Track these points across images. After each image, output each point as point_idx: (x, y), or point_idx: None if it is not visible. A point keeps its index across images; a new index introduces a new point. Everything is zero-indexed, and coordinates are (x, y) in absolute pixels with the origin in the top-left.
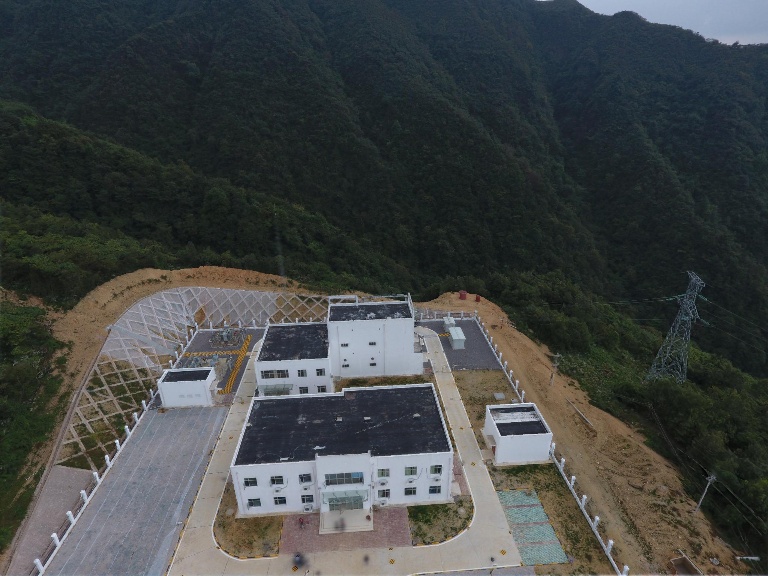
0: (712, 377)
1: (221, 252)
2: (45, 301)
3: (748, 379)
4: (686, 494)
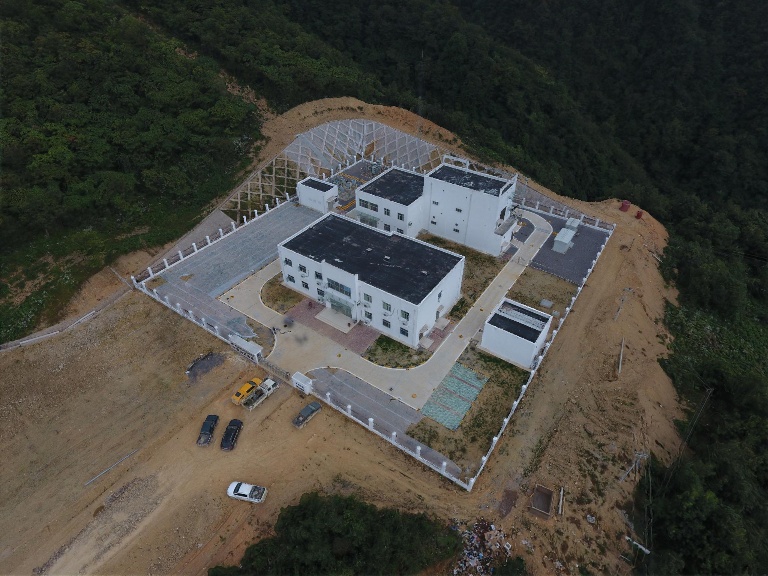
0: None
1: (443, 102)
2: (269, 103)
3: None
4: (643, 470)
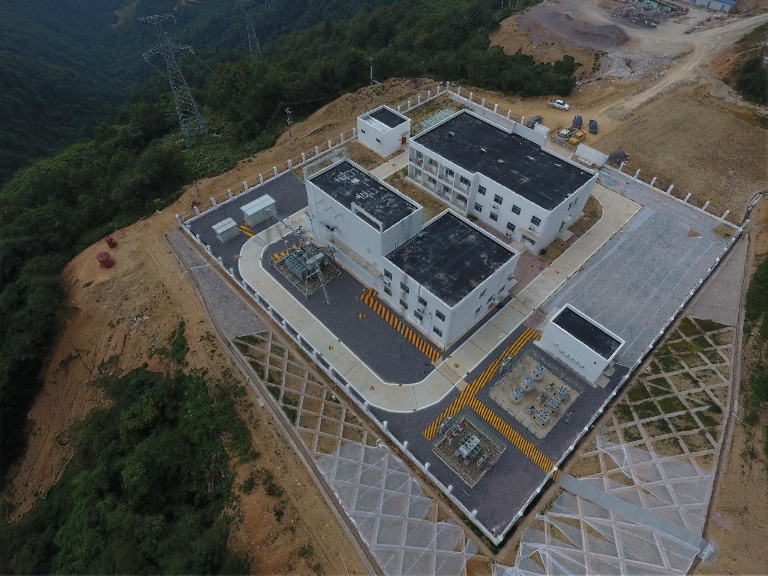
0: (151, 125)
1: None
2: None
3: (84, 145)
4: None
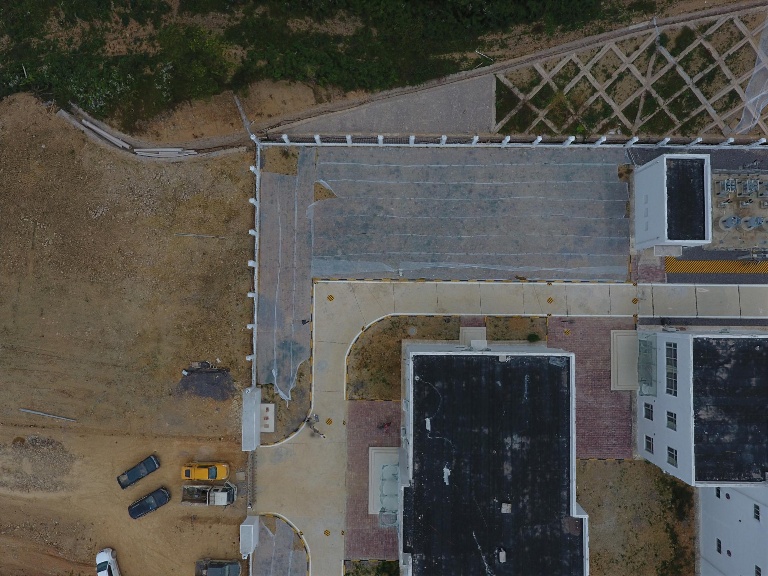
0: None
1: None
2: None
3: None
4: None
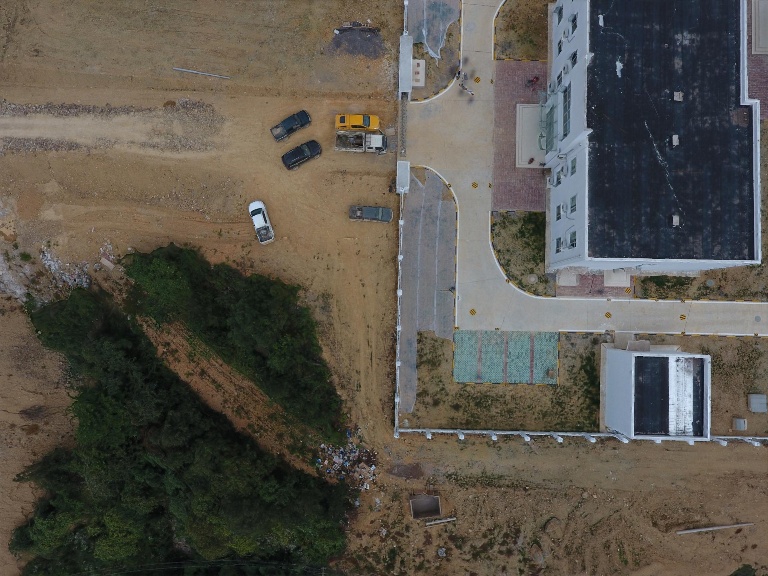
0: None
1: None
2: None
3: None
4: None
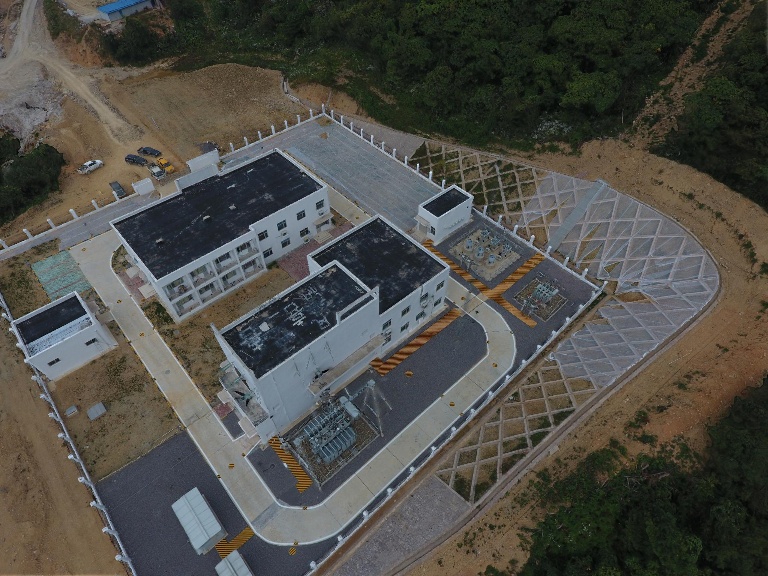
0: None
1: None
2: None
3: None
4: None
